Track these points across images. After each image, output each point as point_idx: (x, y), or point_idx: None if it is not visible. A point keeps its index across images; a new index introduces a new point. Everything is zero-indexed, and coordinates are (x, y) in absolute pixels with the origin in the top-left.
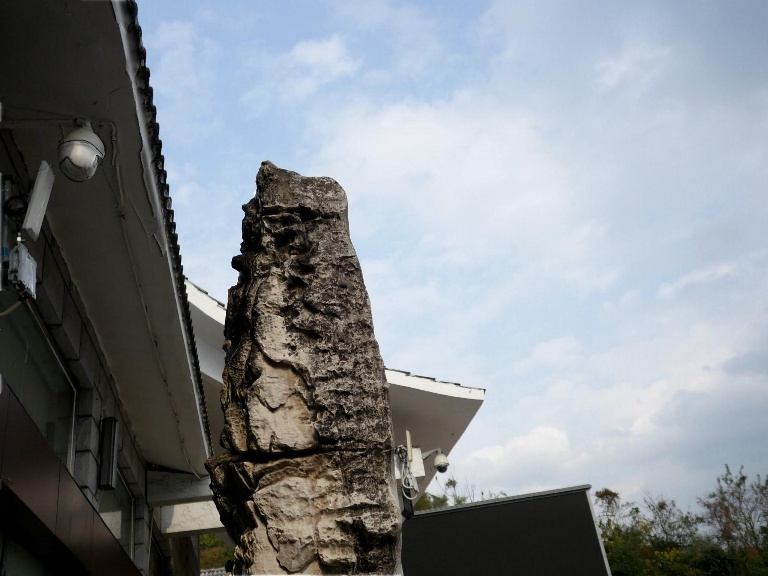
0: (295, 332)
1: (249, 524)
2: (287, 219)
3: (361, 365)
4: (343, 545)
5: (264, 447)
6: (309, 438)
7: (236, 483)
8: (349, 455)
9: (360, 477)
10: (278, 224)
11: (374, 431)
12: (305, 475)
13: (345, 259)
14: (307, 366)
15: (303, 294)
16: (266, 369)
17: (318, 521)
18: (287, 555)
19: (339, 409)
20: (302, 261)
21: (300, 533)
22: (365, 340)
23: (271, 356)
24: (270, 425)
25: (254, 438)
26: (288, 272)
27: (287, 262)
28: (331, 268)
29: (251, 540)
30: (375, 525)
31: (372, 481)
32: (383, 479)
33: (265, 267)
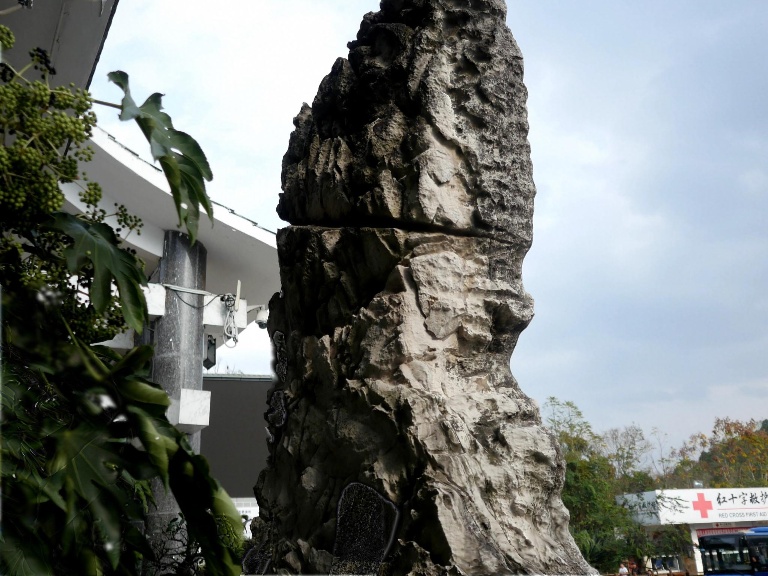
0: (463, 116)
1: (385, 288)
2: (461, 1)
3: (518, 165)
4: (484, 324)
5: (430, 216)
6: (467, 219)
7: (366, 248)
8: (498, 245)
9: (503, 267)
10: (450, 4)
11: (523, 228)
12: (455, 253)
13: (516, 59)
14: (475, 151)
15: (480, 80)
16: (435, 143)
17: (466, 297)
18: (437, 321)
19: (500, 199)
20: (482, 47)
21: (455, 304)
22: (522, 143)
23: (443, 131)
24: (437, 197)
25: (418, 206)
26: (461, 55)
27: (459, 44)
28: (504, 64)
29: (398, 302)
30: (519, 311)
31: (510, 274)
32: (520, 274)
33: (430, 43)
